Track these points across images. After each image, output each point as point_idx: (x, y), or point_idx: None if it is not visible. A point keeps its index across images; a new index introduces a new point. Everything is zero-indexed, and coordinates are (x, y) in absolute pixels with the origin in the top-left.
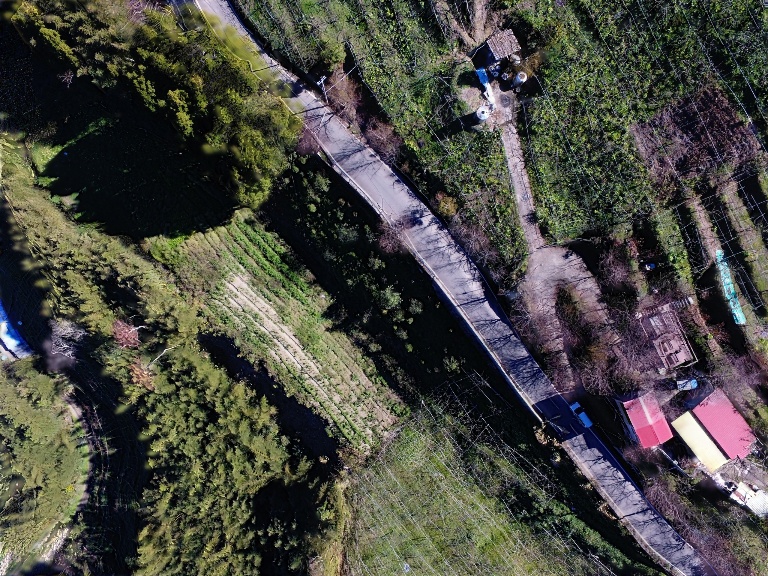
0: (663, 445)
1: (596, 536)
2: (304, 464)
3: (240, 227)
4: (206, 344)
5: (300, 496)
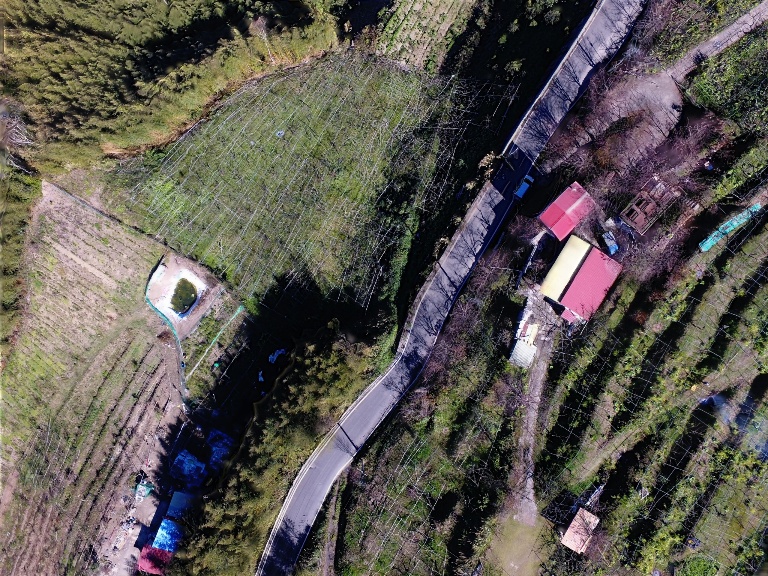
0: (540, 249)
1: (403, 262)
2: (332, 18)
3: None
4: None
5: None
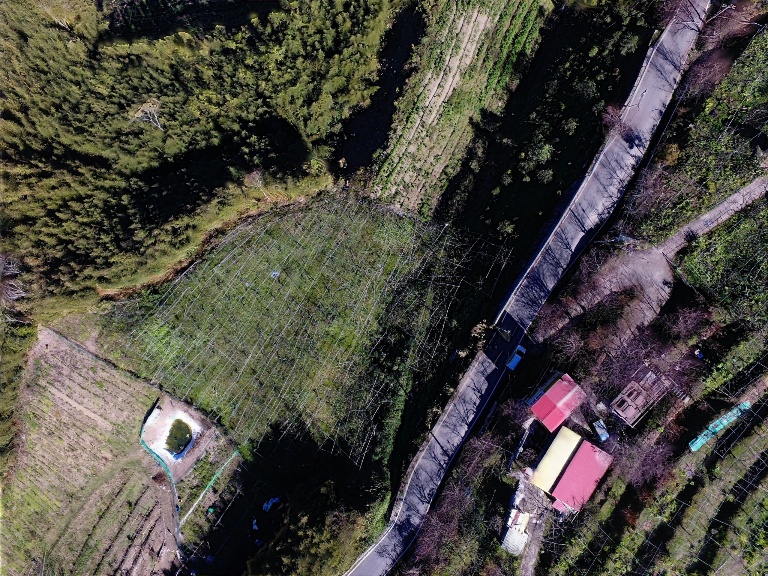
0: (531, 433)
1: (396, 423)
2: (327, 150)
3: (534, 3)
4: (399, 21)
5: (300, 153)
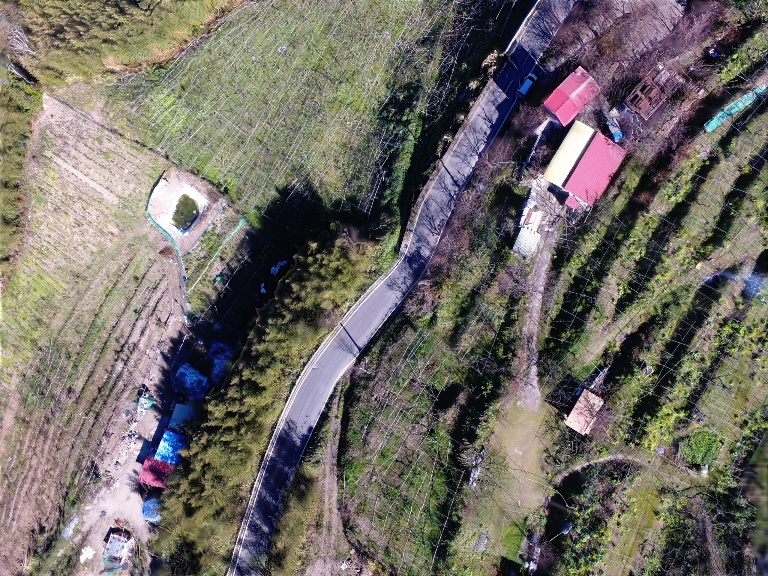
0: (543, 140)
1: (406, 165)
2: None
3: None
4: None
5: None
